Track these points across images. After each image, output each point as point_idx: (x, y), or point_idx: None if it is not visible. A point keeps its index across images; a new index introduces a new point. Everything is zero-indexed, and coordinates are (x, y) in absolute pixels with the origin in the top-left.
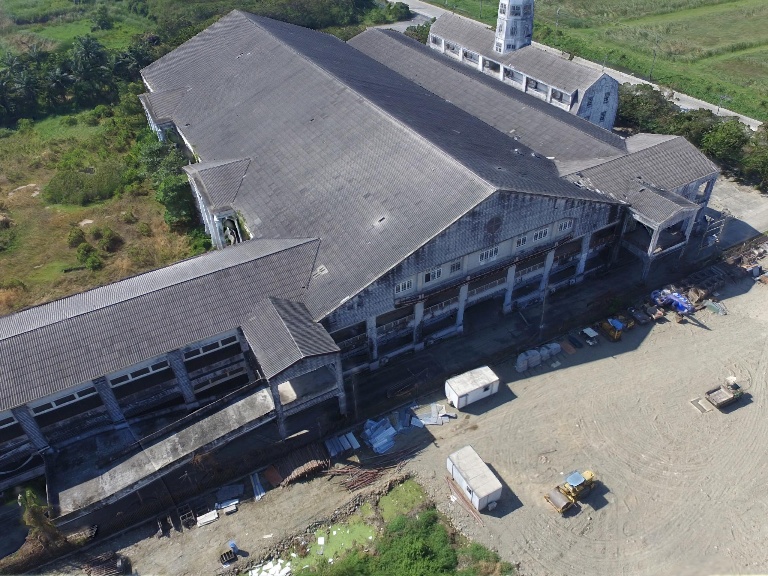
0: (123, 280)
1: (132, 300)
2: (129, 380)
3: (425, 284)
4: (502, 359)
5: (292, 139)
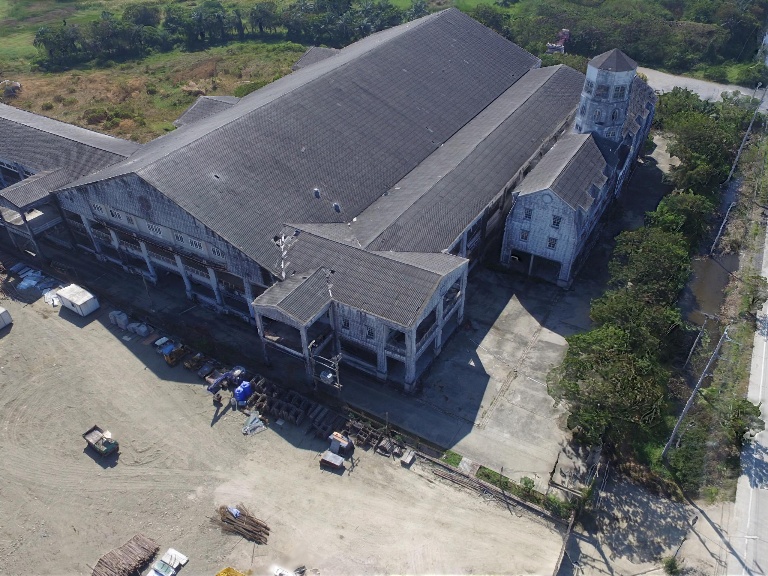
0: None
1: (42, 131)
2: (6, 167)
3: (113, 218)
4: (124, 309)
5: None
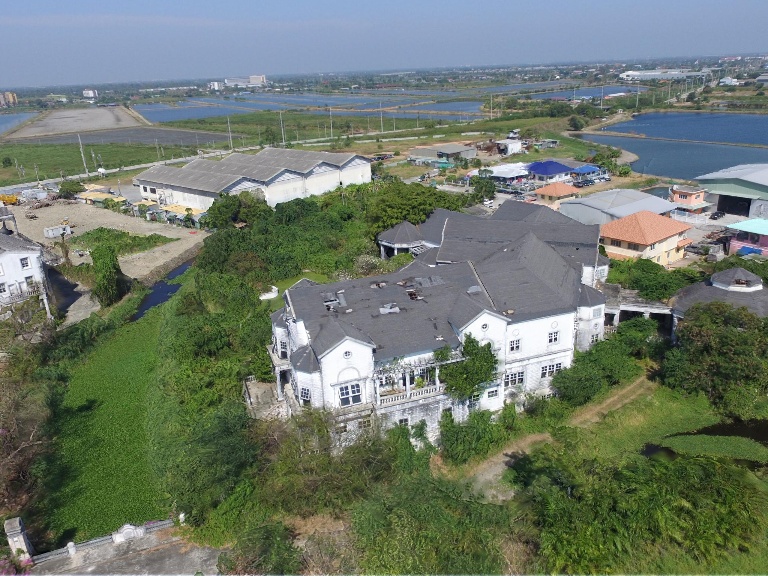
0: None
1: None
2: None
3: None
4: None
5: None
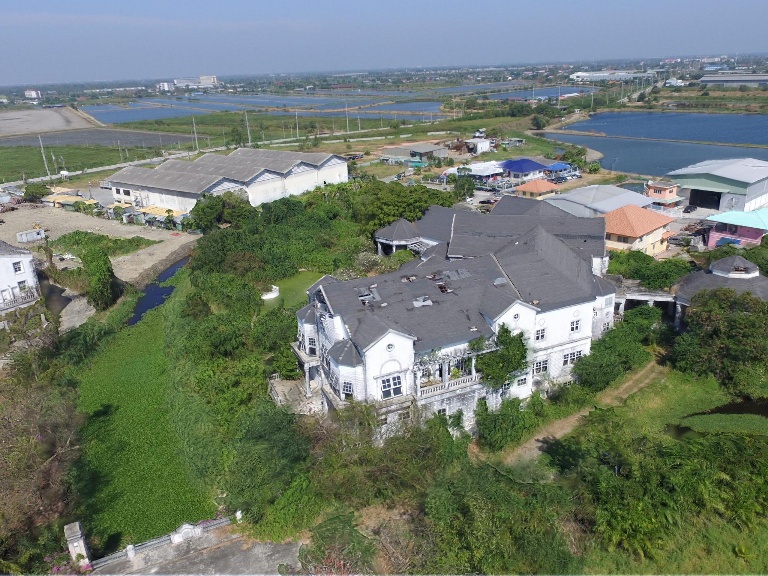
0: None
1: None
2: None
3: None
4: None
5: None
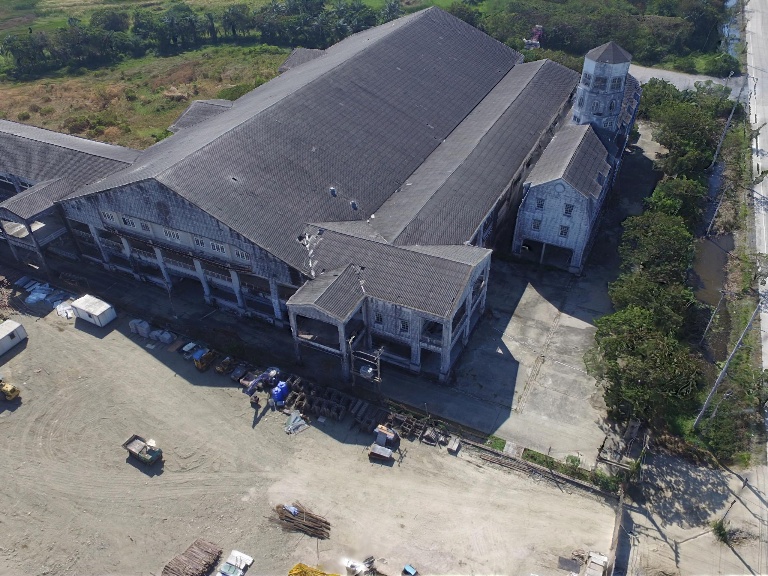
0: (75, 136)
1: (36, 141)
2: None
3: (125, 225)
4: (142, 317)
5: (248, 104)
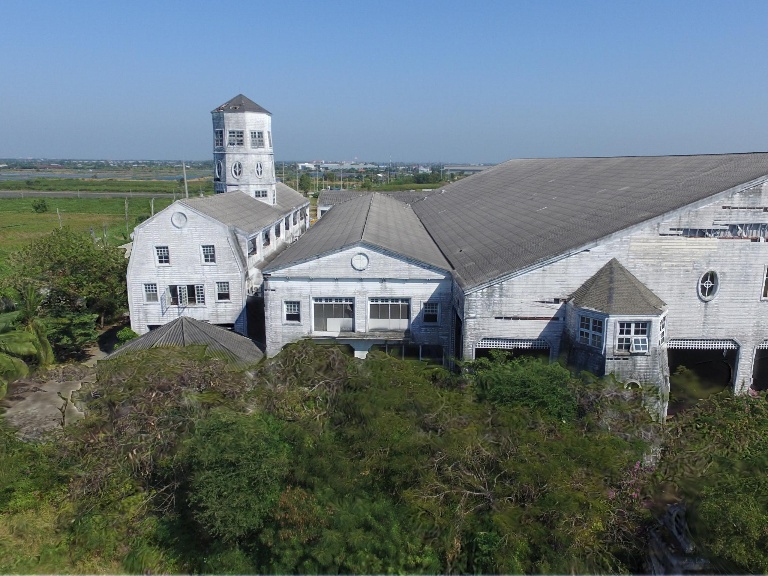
0: None
1: None
2: None
3: None
4: None
5: None
